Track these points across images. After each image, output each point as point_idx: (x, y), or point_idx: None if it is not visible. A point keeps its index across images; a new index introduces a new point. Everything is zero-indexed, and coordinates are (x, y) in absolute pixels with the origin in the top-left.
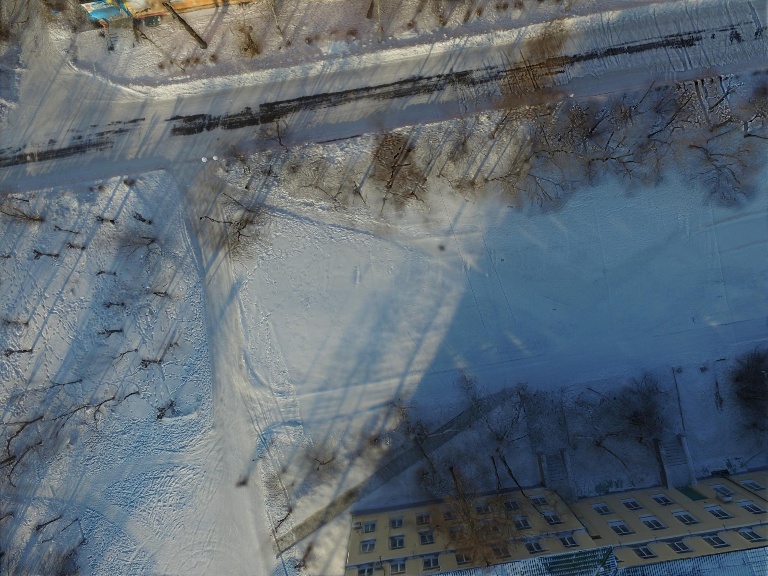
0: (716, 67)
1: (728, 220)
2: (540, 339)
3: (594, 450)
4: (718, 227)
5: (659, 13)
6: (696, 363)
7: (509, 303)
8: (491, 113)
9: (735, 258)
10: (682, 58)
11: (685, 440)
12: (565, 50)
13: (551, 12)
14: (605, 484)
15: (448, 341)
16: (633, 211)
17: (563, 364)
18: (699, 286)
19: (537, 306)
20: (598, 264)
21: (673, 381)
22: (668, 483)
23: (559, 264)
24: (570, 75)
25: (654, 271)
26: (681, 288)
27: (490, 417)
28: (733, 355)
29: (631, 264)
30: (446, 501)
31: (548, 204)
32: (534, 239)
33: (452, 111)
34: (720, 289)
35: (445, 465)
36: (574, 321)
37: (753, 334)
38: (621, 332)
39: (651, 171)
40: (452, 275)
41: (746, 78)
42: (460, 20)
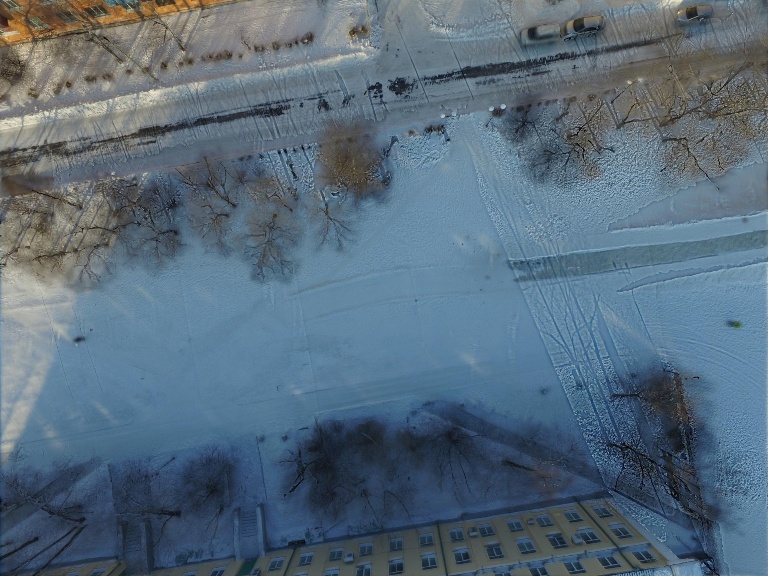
0: (304, 136)
1: (311, 288)
2: (127, 408)
3: (174, 520)
4: (303, 295)
5: (247, 83)
6: (278, 432)
7: (97, 373)
8: (78, 185)
9: (320, 326)
10: (271, 127)
11: (259, 511)
12: (156, 120)
13: (140, 83)
14: (186, 554)
15: (37, 411)
16: (219, 280)
17: (151, 433)
18: (284, 354)
19: (125, 375)
20: (183, 333)
21: (257, 450)
22: (236, 555)
23: (146, 334)
24: (161, 145)
25: (240, 340)
26: (267, 356)
27: (77, 487)
28: (313, 424)
29: (216, 333)
30: (25, 572)
31: (135, 274)
32: (121, 309)
33: (46, 182)
34: (306, 357)
35: (31, 535)
36: (162, 390)
37: (335, 403)
38: (207, 401)
39: (213, 244)
40: (41, 345)
41: (330, 147)
42: (52, 92)
